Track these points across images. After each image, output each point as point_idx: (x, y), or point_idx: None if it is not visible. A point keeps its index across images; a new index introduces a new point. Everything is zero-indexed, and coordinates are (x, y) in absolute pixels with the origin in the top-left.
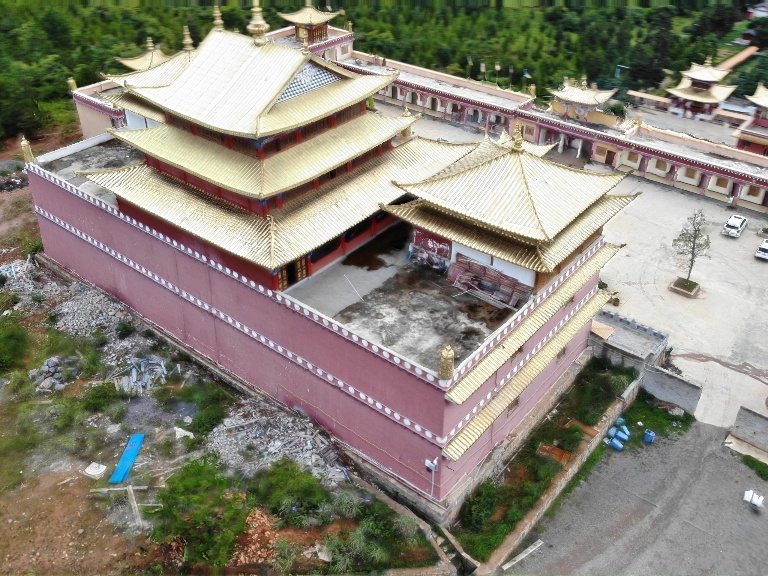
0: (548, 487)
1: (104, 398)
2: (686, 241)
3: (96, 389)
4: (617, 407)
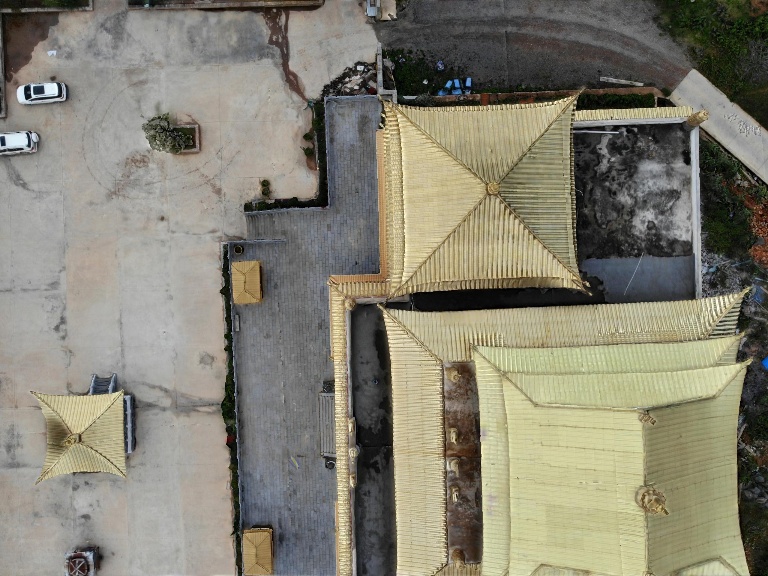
0: (562, 96)
1: (766, 419)
2: (174, 138)
3: (764, 435)
4: (441, 96)
